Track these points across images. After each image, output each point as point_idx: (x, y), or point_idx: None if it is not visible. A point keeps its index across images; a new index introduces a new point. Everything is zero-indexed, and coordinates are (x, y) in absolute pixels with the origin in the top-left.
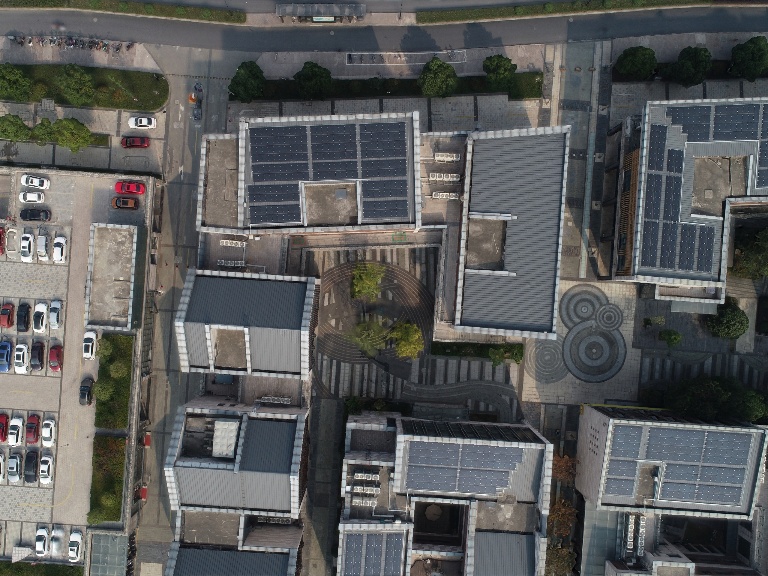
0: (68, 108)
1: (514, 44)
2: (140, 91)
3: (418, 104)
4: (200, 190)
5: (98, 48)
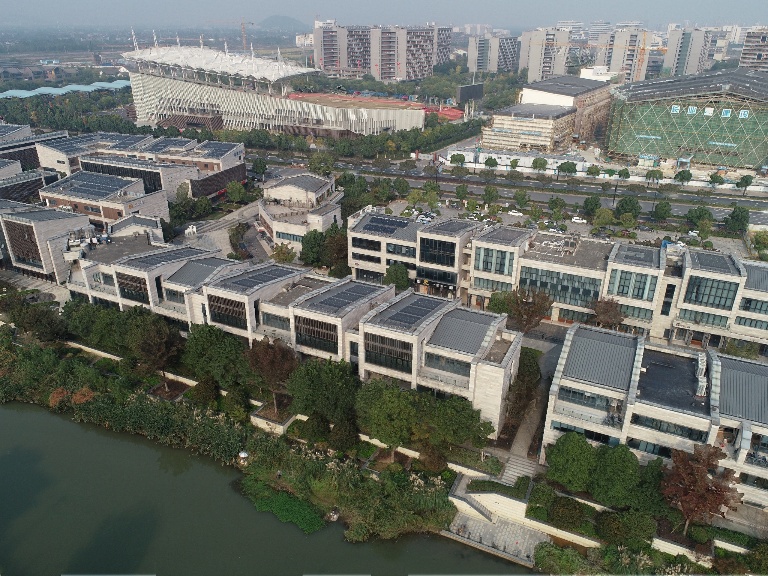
0: None
1: None
2: None
3: None
4: None
5: None
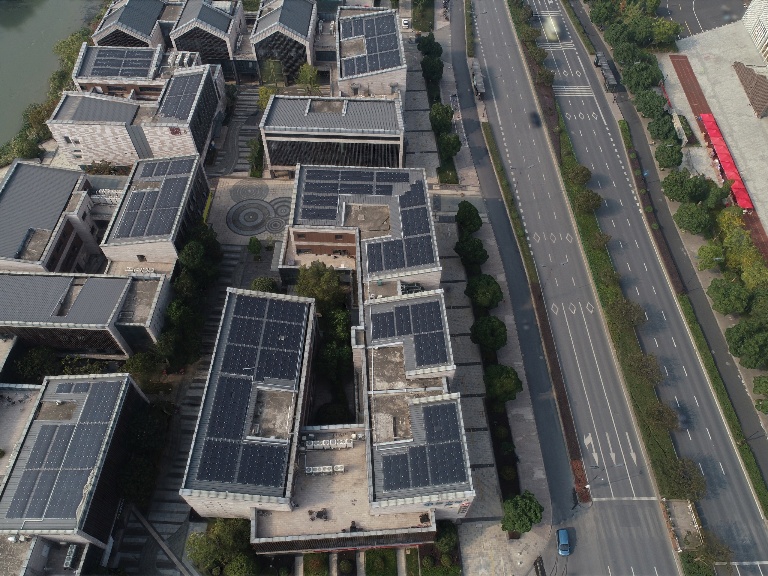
0: (411, 2)
1: (477, 171)
2: (423, 22)
3: (429, 126)
4: (360, 7)
5: (444, 9)
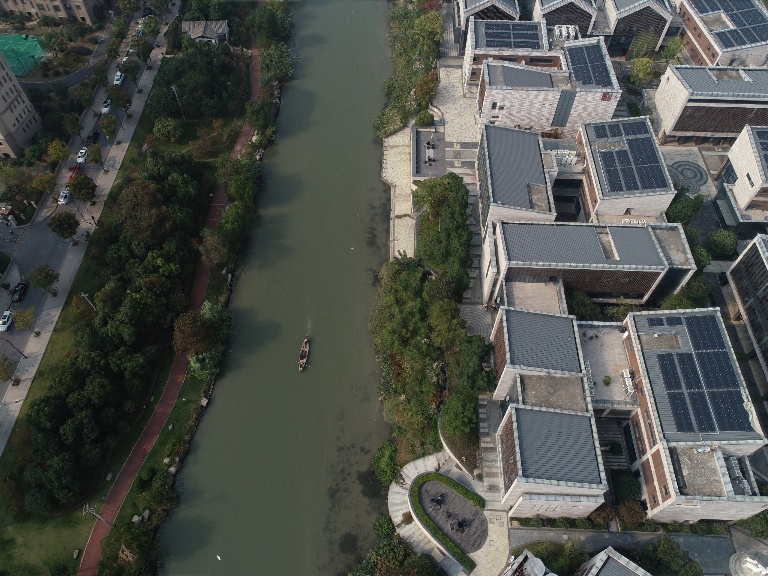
0: None
1: None
2: None
3: None
4: None
5: None
